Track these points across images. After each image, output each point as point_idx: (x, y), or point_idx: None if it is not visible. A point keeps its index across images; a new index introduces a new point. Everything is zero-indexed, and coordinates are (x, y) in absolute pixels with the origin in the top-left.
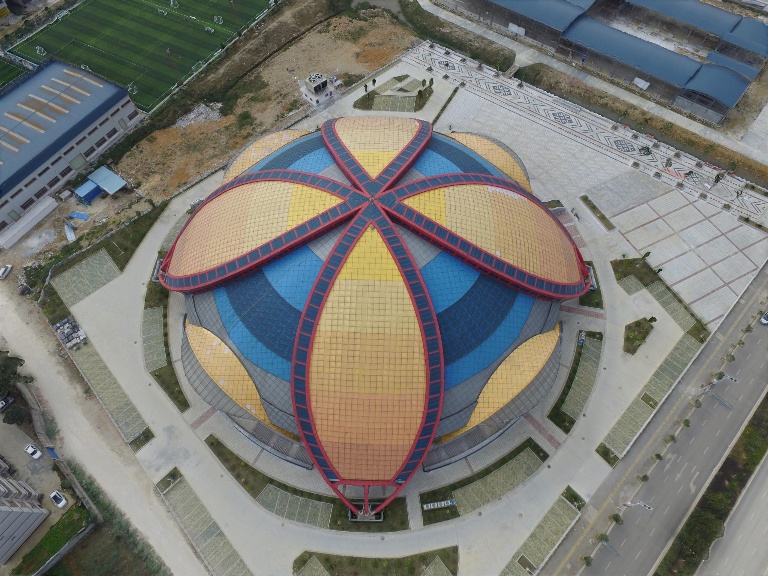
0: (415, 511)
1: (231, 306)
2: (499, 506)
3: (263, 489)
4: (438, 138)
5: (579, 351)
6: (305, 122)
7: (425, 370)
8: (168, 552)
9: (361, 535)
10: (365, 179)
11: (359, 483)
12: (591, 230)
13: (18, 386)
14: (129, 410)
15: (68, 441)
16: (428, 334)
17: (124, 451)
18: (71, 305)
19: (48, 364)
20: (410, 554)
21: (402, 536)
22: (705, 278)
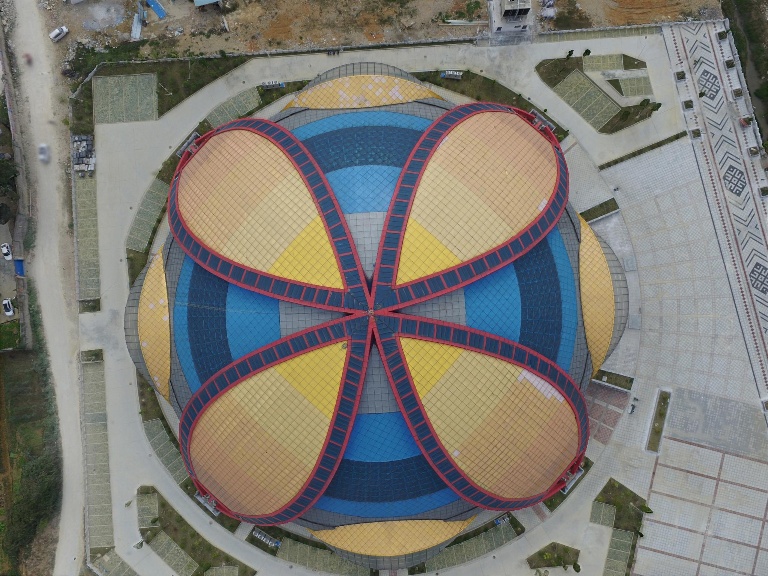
0: (247, 526)
1: (189, 285)
2: (309, 574)
3: (153, 419)
4: (551, 240)
5: (488, 527)
6: (463, 49)
7: (297, 492)
8: (64, 407)
9: (198, 508)
10: (387, 278)
11: (208, 492)
12: (631, 433)
13: (17, 182)
14: (94, 271)
15: (37, 262)
16: (319, 475)
17: (72, 304)
18: (98, 122)
19: (53, 173)
20: (221, 549)
21: (225, 533)
22: (681, 568)
